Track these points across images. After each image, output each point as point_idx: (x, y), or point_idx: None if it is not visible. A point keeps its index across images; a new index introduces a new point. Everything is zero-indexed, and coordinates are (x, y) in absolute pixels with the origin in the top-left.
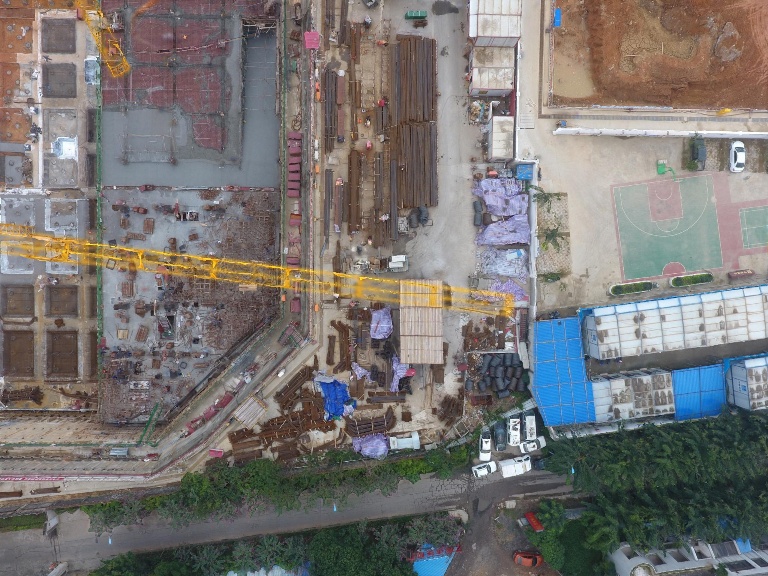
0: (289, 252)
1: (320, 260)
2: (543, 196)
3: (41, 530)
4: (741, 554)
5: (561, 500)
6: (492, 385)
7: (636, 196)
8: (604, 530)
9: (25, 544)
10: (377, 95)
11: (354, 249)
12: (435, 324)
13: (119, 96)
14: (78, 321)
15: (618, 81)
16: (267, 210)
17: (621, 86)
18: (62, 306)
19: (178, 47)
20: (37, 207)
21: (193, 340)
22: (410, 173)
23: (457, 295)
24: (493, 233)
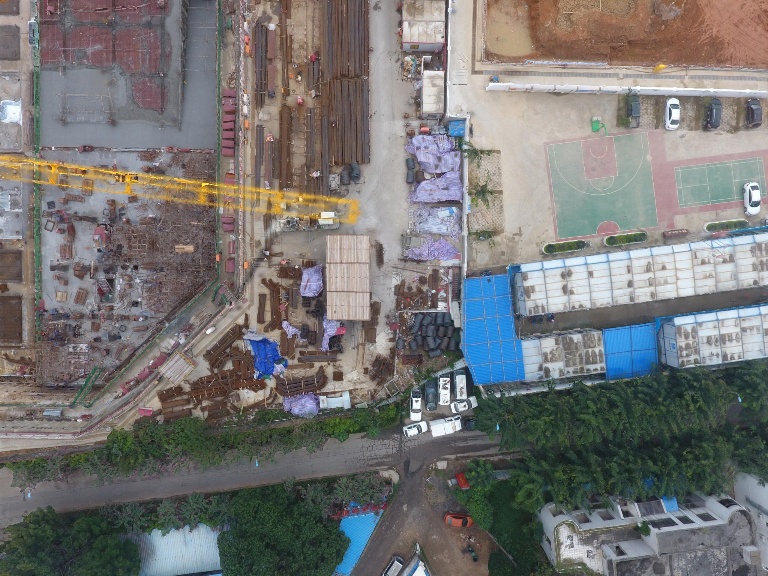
0: (224, 212)
1: (251, 217)
2: (473, 151)
3: None
4: (667, 512)
5: (493, 461)
6: (423, 344)
7: (570, 154)
8: (527, 486)
9: None
10: (309, 50)
11: (283, 205)
12: (362, 280)
13: (58, 56)
14: (22, 286)
15: (555, 38)
16: (205, 171)
17: (558, 44)
18: (6, 271)
19: (117, 6)
20: None
21: (132, 303)
22: (341, 129)
23: (389, 254)
24: (425, 190)
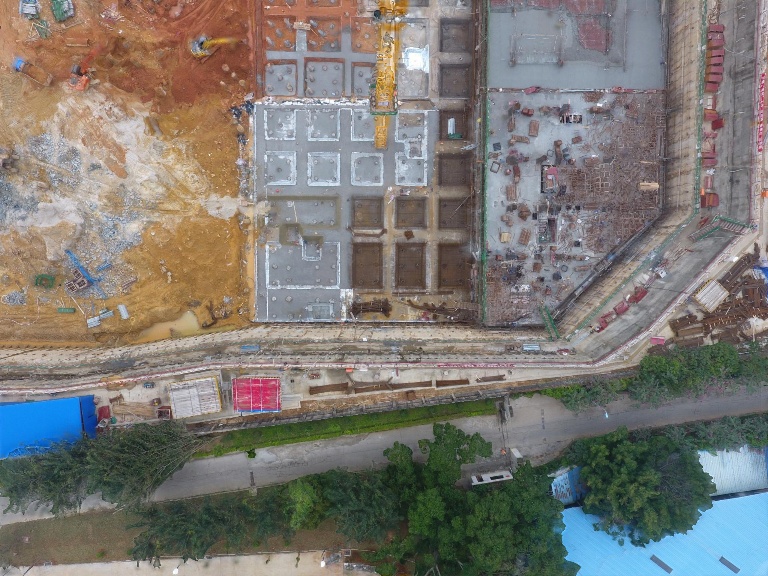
0: None
1: None
2: None
3: (489, 417)
4: None
5: None
6: None
7: None
8: None
9: (474, 431)
10: None
11: None
12: None
13: None
14: (426, 233)
15: None
16: (661, 110)
17: None
18: (409, 218)
19: None
20: (388, 118)
21: (576, 243)
22: None
23: None
24: None
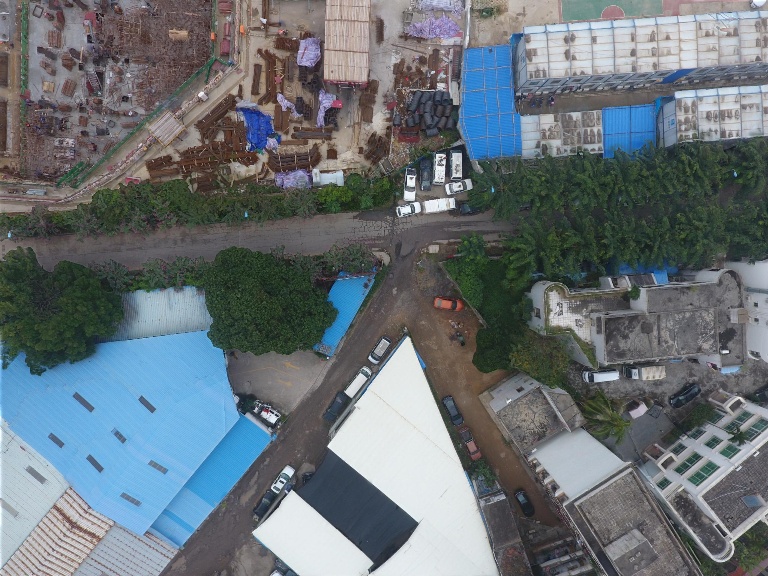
0: None
1: None
2: None
3: None
4: (657, 284)
5: (485, 248)
6: (421, 123)
7: None
8: (519, 245)
9: None
10: None
11: None
12: (361, 39)
13: None
14: (8, 91)
15: None
16: None
17: None
18: None
19: None
20: None
21: (122, 97)
22: None
23: (390, 31)
24: None
